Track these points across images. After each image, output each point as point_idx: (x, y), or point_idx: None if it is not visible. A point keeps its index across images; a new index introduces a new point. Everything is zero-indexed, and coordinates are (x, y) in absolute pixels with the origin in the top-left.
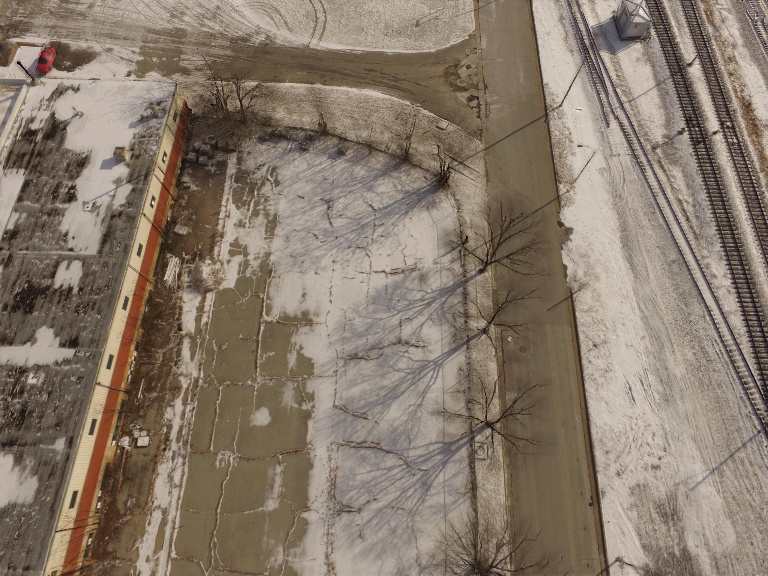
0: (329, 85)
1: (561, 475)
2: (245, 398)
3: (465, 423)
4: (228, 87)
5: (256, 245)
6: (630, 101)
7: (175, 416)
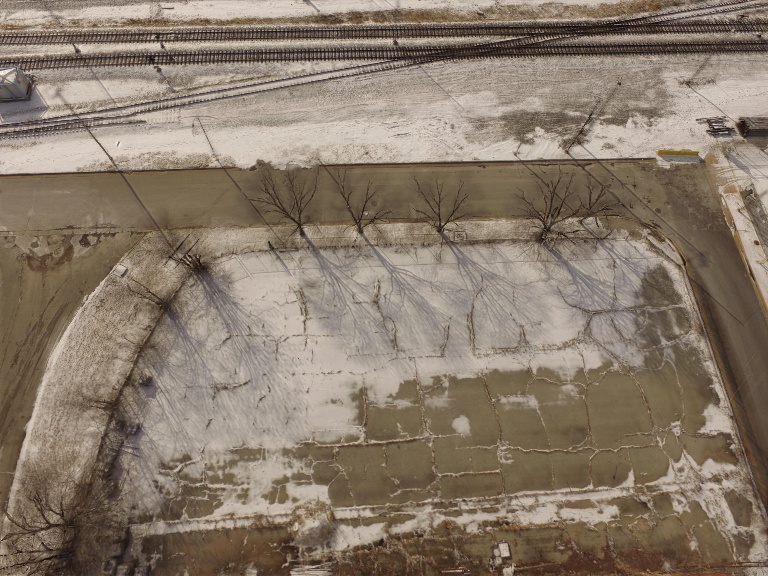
0: (31, 411)
1: (468, 184)
2: (446, 446)
3: (440, 248)
4: (5, 568)
5: (273, 469)
6: (114, 102)
7: (474, 521)
